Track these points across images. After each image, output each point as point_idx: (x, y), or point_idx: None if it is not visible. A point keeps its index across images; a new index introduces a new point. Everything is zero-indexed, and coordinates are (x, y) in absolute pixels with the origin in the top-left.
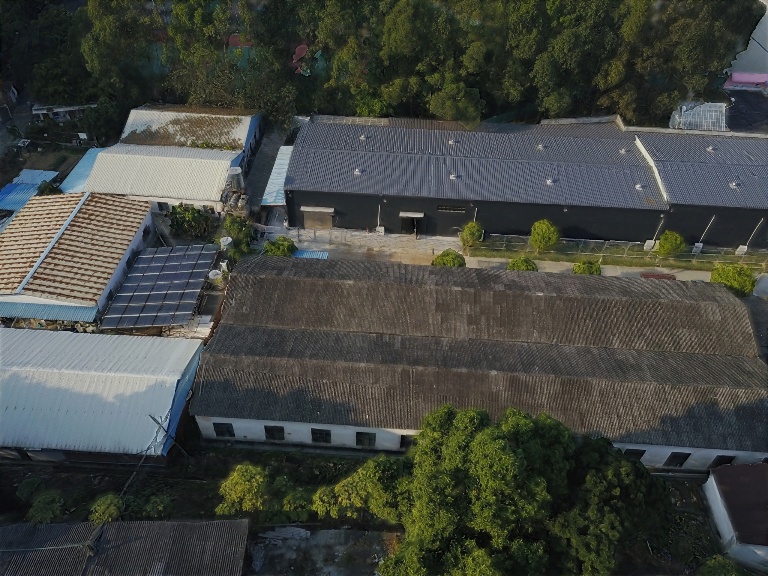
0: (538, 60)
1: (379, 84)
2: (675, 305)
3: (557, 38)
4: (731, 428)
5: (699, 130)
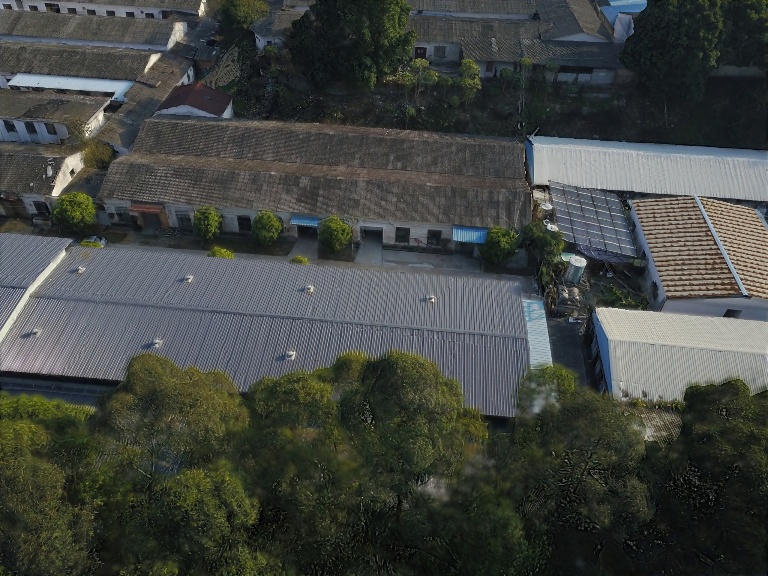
0: None
1: None
2: (168, 164)
3: None
4: (197, 118)
5: None
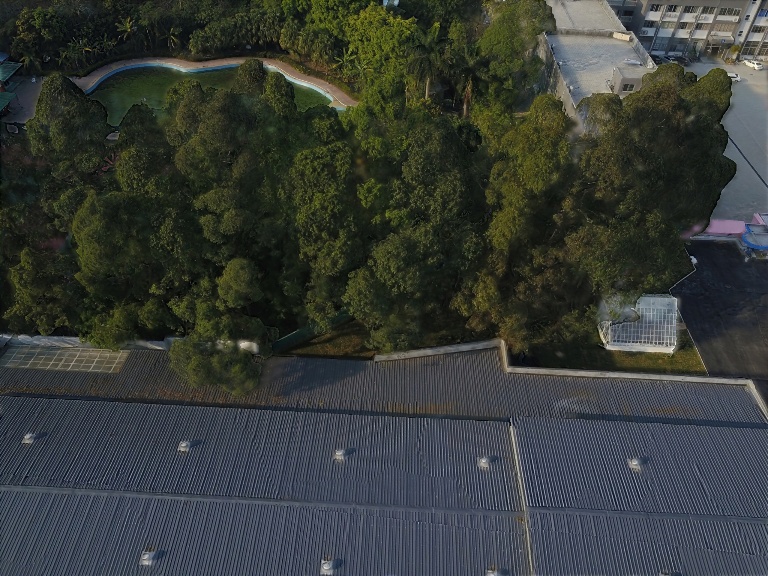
0: (351, 280)
1: (114, 295)
2: None
3: (378, 248)
4: None
5: (628, 372)
